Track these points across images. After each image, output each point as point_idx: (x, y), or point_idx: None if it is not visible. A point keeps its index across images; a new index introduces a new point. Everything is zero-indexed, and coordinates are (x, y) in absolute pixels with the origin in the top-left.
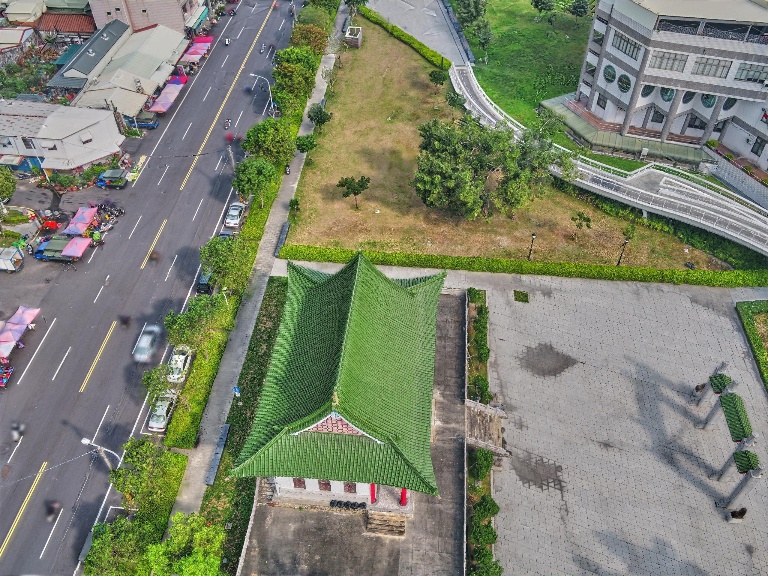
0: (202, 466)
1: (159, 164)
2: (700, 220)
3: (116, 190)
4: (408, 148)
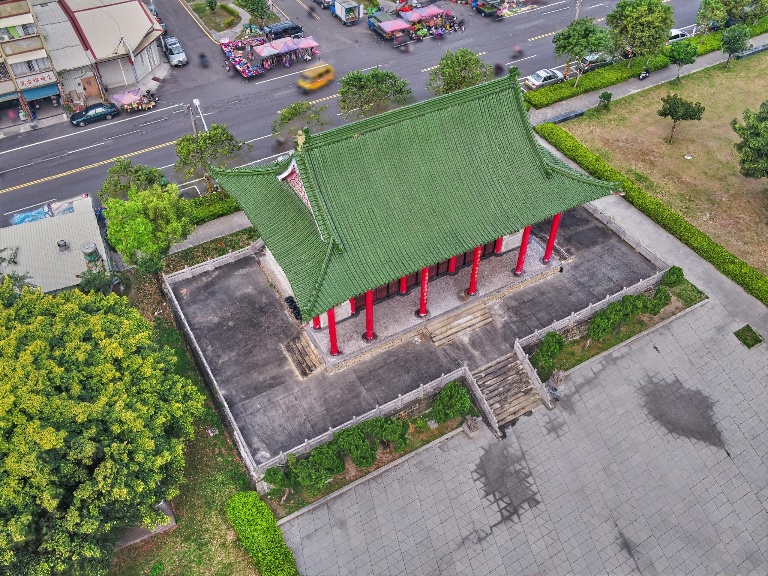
0: None
1: None
2: None
3: (481, 15)
4: None
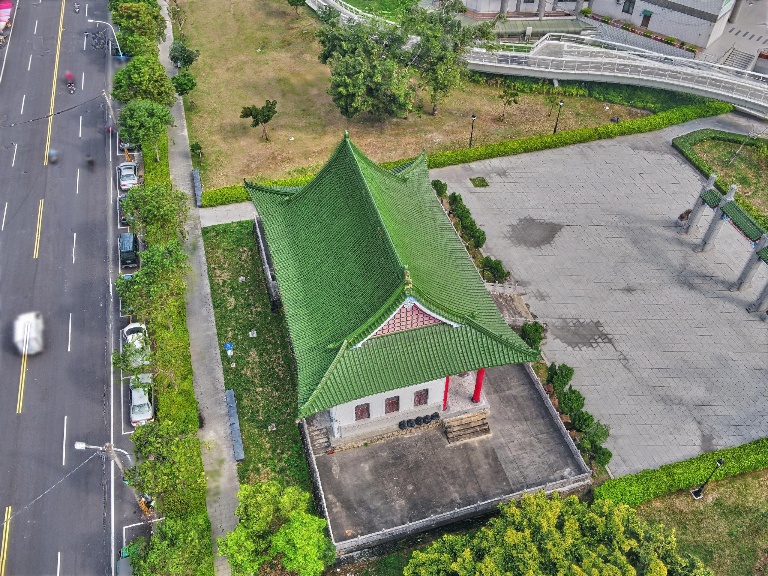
0: (220, 444)
1: (3, 144)
2: (614, 73)
3: None
4: (294, 73)
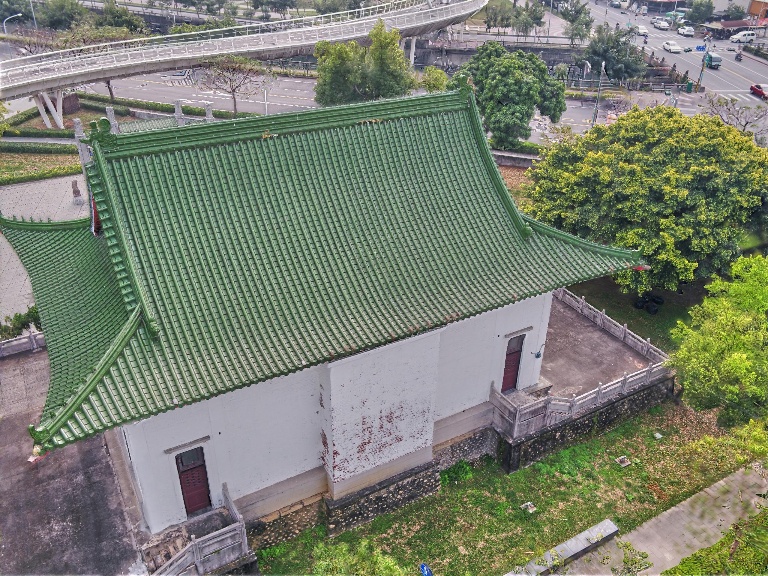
0: None
1: None
2: None
3: None
4: None
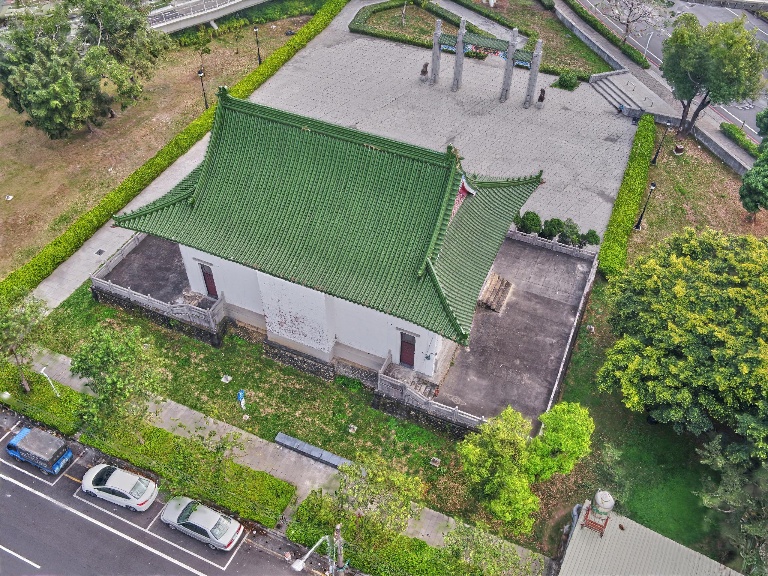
0: (329, 483)
1: None
2: None
3: None
4: None
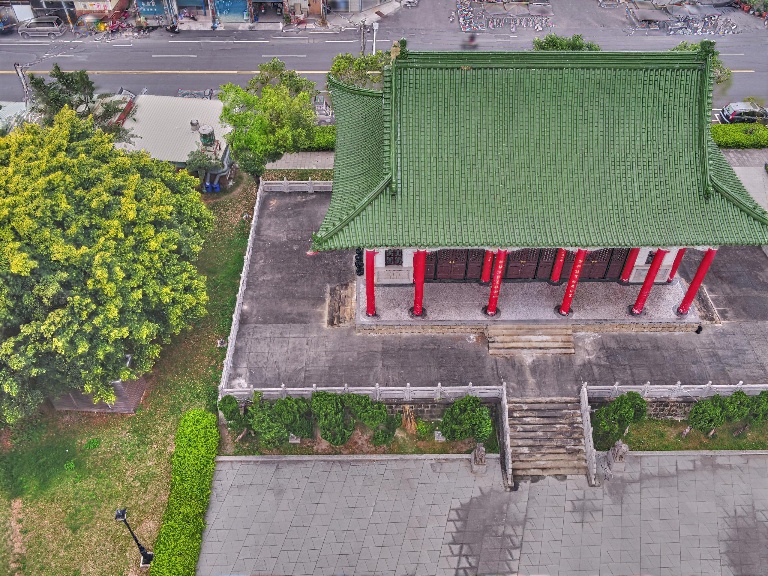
0: None
1: None
2: None
3: None
4: None
